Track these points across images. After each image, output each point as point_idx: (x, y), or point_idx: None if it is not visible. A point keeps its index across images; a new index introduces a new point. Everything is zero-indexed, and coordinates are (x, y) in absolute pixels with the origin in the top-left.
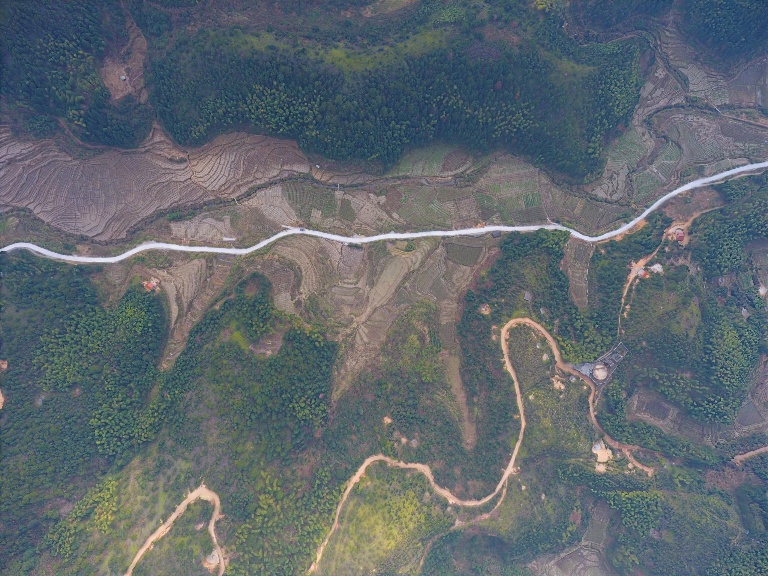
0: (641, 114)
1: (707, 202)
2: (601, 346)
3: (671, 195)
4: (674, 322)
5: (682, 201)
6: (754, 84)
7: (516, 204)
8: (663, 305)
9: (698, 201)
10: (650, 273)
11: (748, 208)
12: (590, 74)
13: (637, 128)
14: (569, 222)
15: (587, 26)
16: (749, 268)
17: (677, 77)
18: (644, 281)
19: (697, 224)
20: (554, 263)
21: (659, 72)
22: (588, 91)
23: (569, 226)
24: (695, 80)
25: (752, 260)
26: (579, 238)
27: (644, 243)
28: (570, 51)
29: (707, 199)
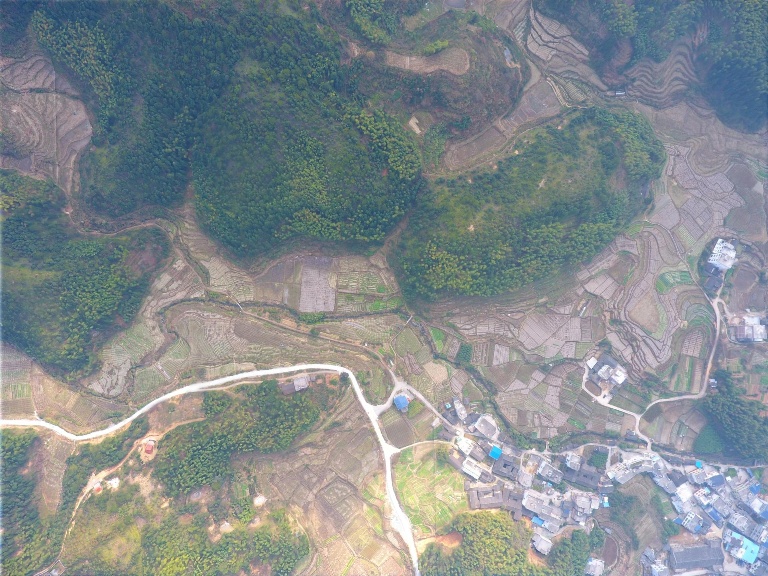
0: (155, 306)
1: (191, 412)
2: (35, 563)
3: (163, 398)
4: (105, 548)
5: (167, 408)
6: (283, 282)
7: (3, 394)
8: (101, 527)
9: (182, 410)
10: (102, 489)
11: (215, 428)
12: (43, 282)
13: (148, 321)
14: (55, 418)
15: (92, 214)
16: (246, 477)
17: (197, 270)
18: (89, 499)
19: (163, 439)
20: (1, 471)
21: (178, 263)
22: (45, 298)
23: (52, 423)
24: (216, 274)
25: (252, 468)
26: (63, 435)
27: (109, 454)
28: (31, 254)
29: (193, 408)
